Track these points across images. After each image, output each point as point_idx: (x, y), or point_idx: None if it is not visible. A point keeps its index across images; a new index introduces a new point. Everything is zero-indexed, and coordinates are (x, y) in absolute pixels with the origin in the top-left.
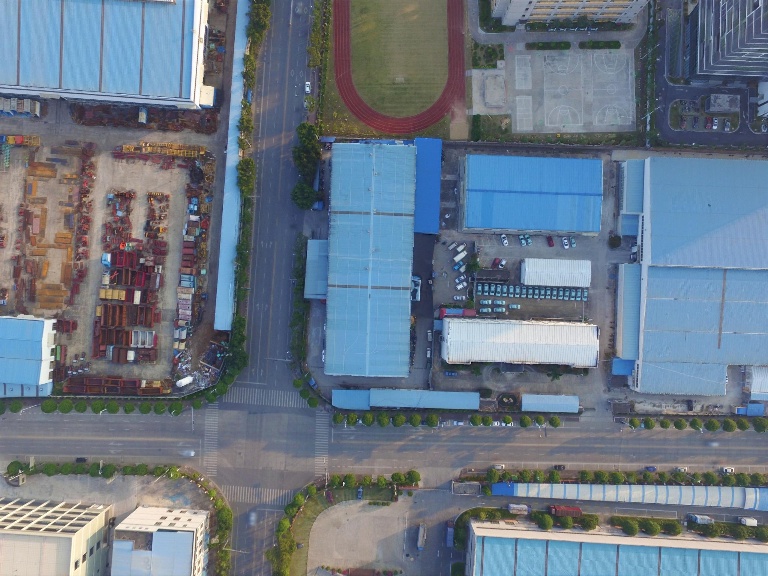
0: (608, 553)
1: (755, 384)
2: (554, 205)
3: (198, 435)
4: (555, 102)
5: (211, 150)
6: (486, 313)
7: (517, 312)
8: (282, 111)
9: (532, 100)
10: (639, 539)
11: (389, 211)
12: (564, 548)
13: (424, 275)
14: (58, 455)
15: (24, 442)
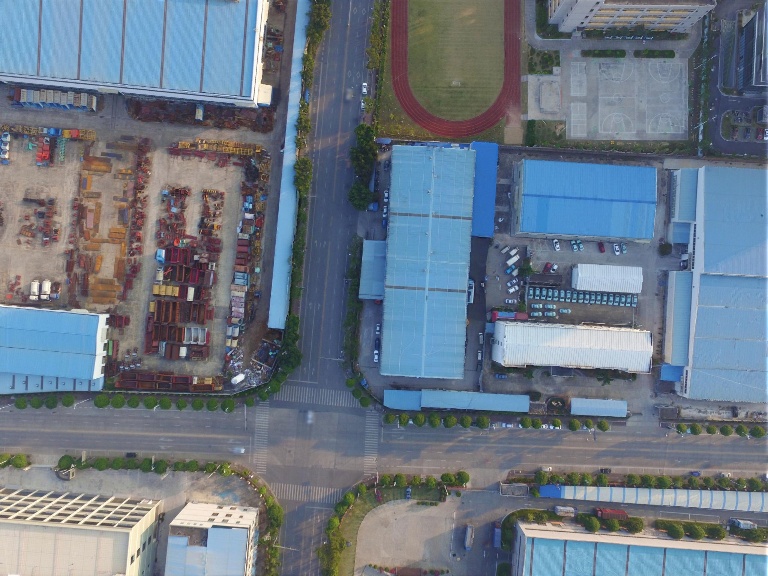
0: (655, 556)
1: None
2: (608, 212)
3: (248, 432)
4: (609, 109)
5: (267, 149)
6: (537, 317)
7: (567, 316)
8: (338, 111)
9: (586, 107)
10: (685, 543)
11: (448, 214)
12: (612, 550)
13: (477, 278)
14: (108, 450)
15: (74, 436)
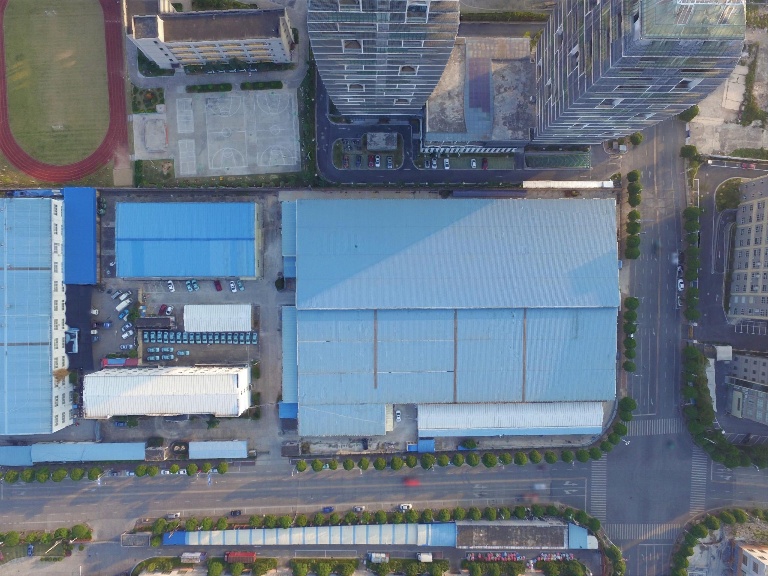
0: None
1: (421, 421)
2: (206, 251)
3: None
4: (218, 145)
5: None
6: (154, 361)
7: (187, 358)
8: None
9: (195, 143)
10: None
11: (24, 266)
12: None
13: (83, 326)
14: None
15: None
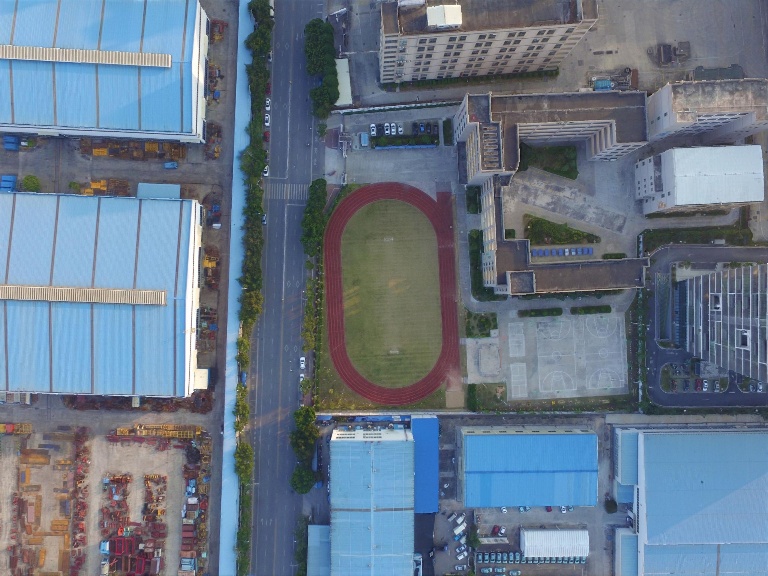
0: None
1: None
2: (551, 482)
3: None
4: (549, 368)
5: (207, 429)
6: None
7: None
8: (277, 387)
9: (526, 367)
10: None
11: (389, 506)
12: None
13: (425, 551)
14: None
15: None
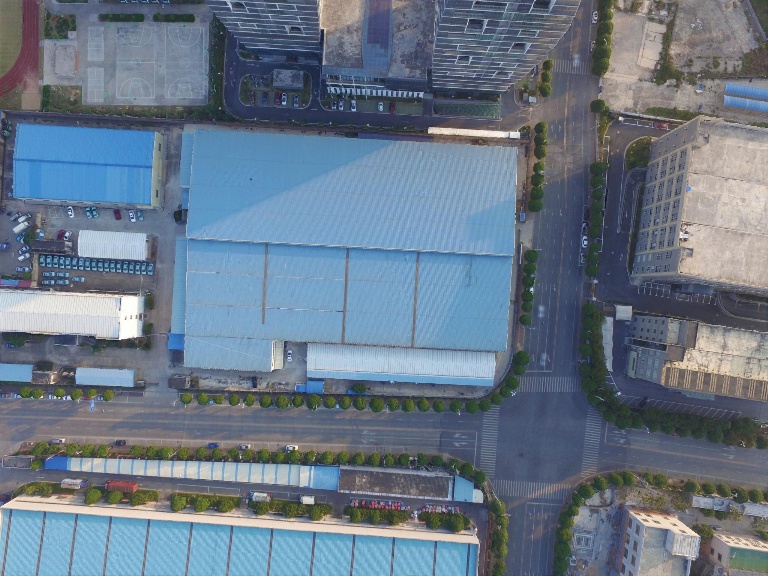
0: (138, 528)
1: (309, 361)
2: (103, 176)
3: None
4: (127, 74)
5: None
6: (49, 285)
7: (82, 285)
8: None
9: (104, 72)
10: (178, 515)
11: None
12: (93, 522)
13: None
14: None
15: None
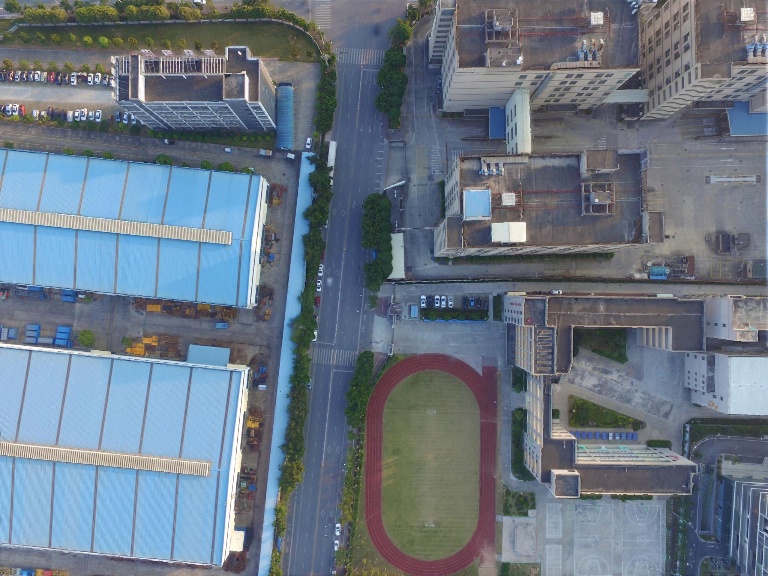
0: None
1: None
2: None
3: None
4: (585, 552)
5: None
6: None
7: None
8: (311, 551)
9: (562, 549)
10: None
11: None
12: None
13: None
14: None
15: None
